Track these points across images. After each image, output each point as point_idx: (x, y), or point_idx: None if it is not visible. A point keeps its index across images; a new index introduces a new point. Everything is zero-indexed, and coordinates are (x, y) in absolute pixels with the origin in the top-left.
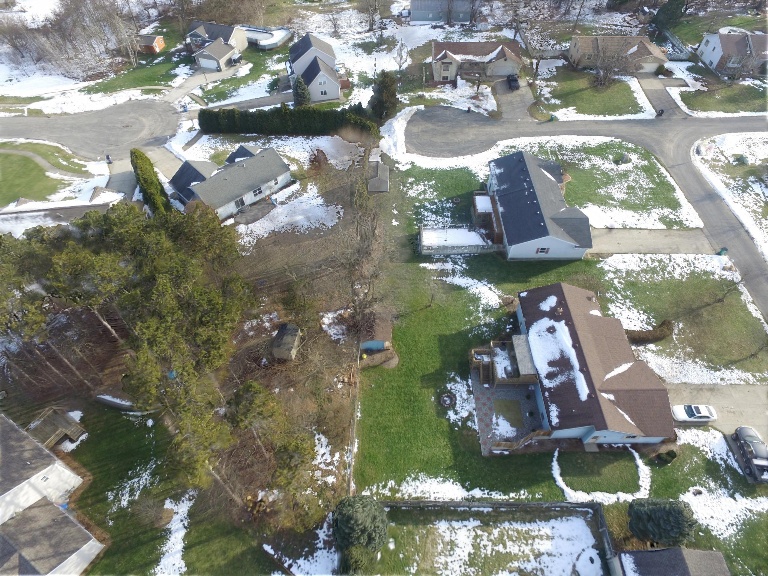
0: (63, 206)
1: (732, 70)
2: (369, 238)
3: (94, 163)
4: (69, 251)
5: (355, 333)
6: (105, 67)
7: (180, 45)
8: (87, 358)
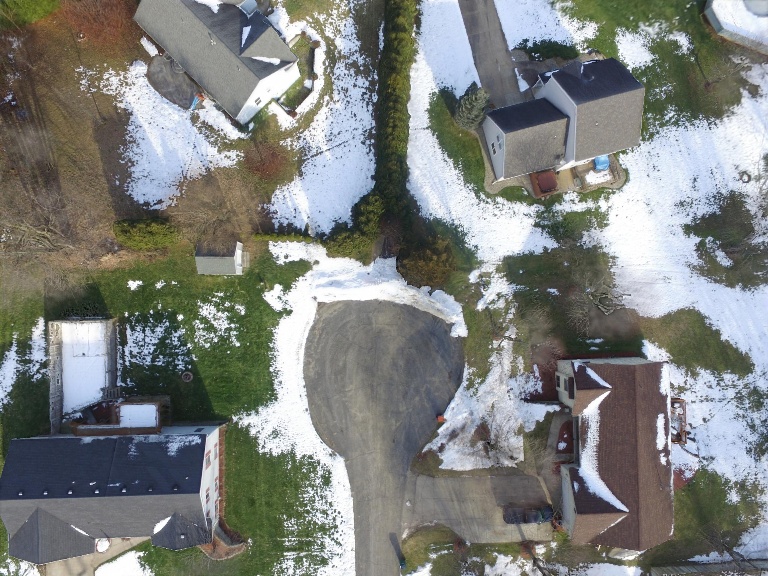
0: None
1: None
2: None
3: None
4: None
5: None
6: None
7: None
8: None
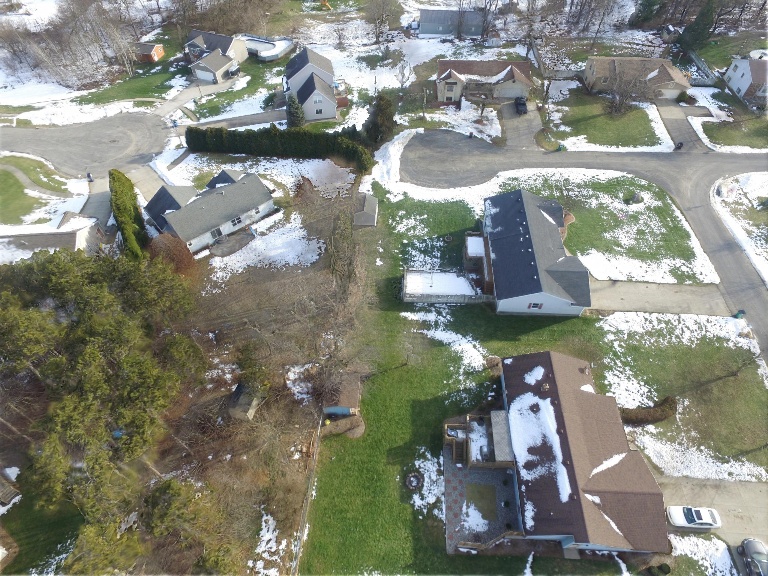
0: (29, 233)
1: (762, 99)
2: (346, 283)
3: (75, 181)
4: (2, 302)
5: (320, 394)
6: (101, 76)
7: (180, 54)
8: (25, 413)
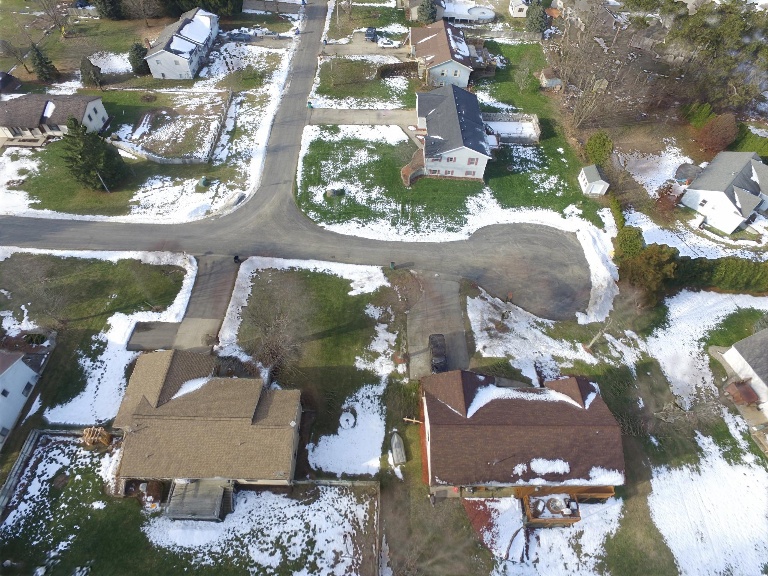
0: None
1: None
2: None
3: None
4: None
5: None
6: None
7: None
8: None
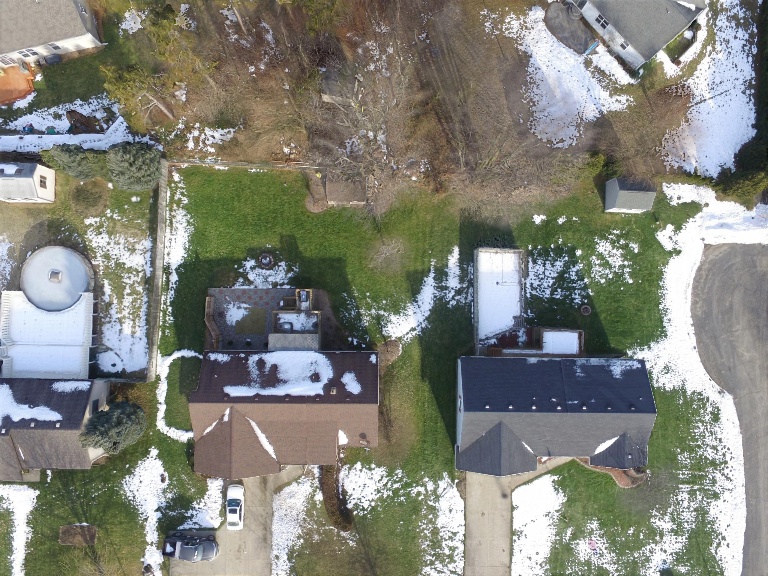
0: None
1: None
2: None
3: None
4: None
5: None
6: None
7: None
8: None
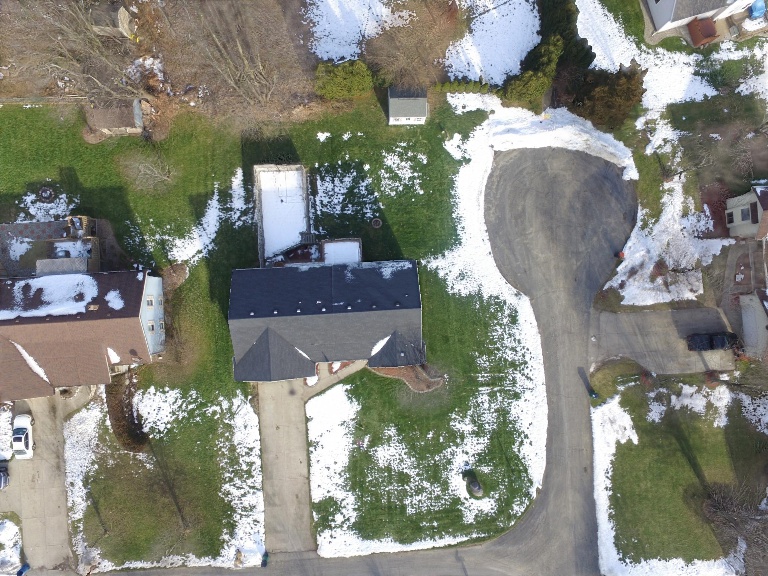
0: None
1: None
2: None
3: None
4: None
5: None
6: None
7: None
8: None
